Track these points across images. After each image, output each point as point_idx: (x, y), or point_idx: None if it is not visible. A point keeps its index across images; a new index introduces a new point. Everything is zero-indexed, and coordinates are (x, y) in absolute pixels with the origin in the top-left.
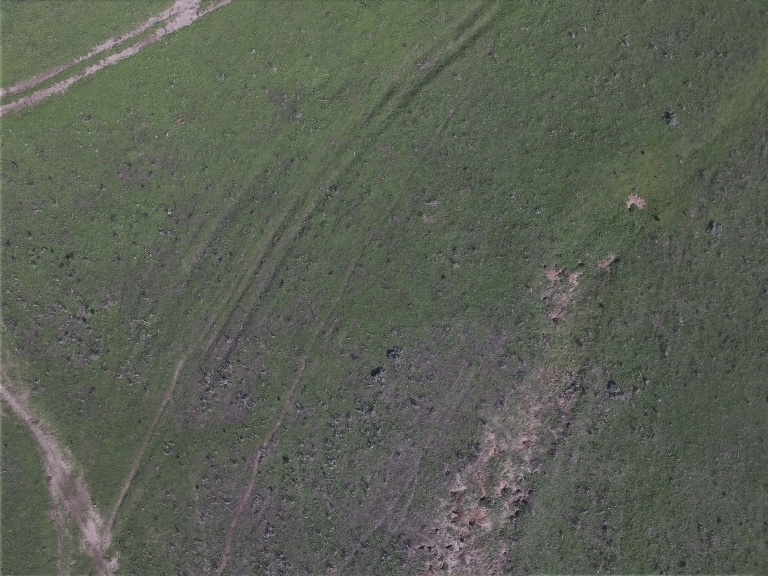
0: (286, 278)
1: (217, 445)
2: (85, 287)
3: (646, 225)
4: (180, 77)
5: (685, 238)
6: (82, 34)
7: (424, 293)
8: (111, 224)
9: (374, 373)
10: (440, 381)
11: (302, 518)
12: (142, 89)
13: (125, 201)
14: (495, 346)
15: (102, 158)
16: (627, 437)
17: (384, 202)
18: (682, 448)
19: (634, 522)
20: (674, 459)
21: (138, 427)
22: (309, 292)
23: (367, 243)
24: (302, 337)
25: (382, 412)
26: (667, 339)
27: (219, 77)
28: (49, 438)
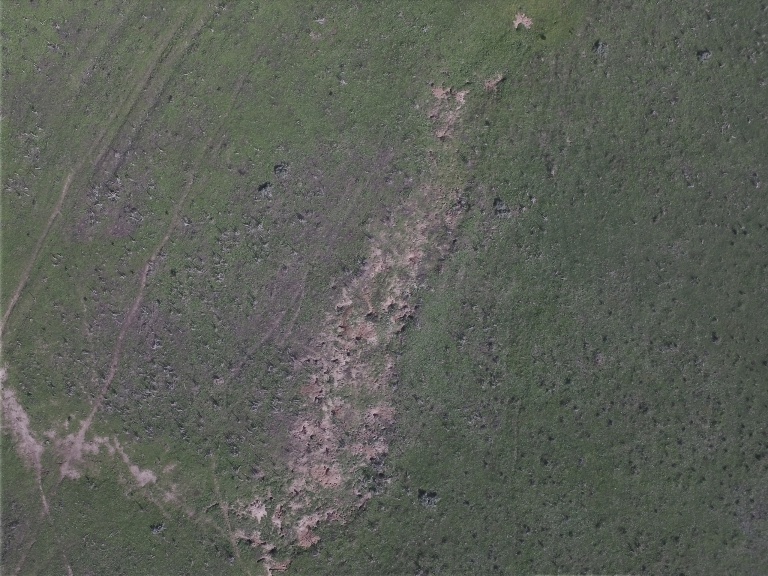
0: (174, 94)
1: (105, 258)
2: None
3: (533, 44)
4: None
5: (571, 57)
6: None
7: (312, 110)
8: None
9: (261, 188)
10: (327, 197)
11: (189, 331)
12: None
13: (14, 16)
14: (382, 163)
15: None
16: (513, 255)
17: (272, 20)
18: (569, 267)
19: (520, 339)
20: (561, 278)
21: (27, 239)
22: (197, 108)
23: (255, 60)
24: (190, 152)
25: (269, 227)
26: (554, 158)
27: None
28: None
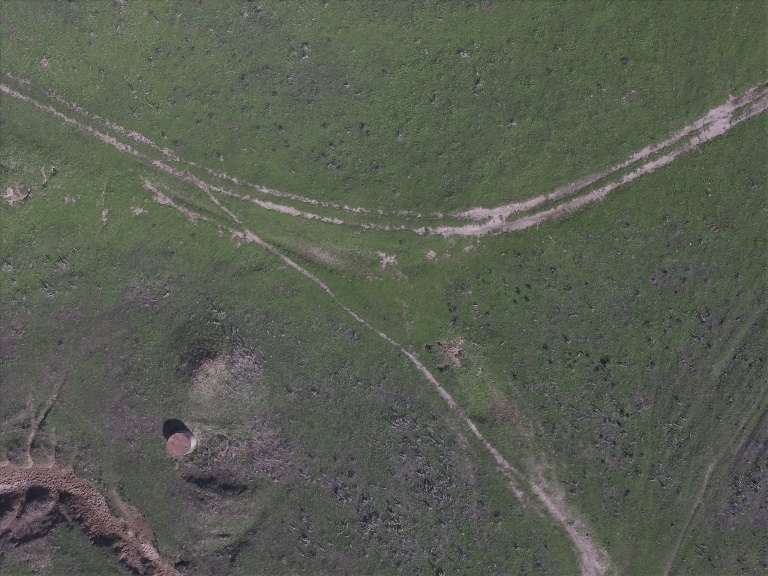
0: None
1: (747, 548)
2: (619, 391)
3: None
4: (714, 185)
5: None
6: (621, 143)
7: None
8: (645, 329)
9: None
10: None
11: None
12: (678, 197)
13: (658, 307)
14: None
15: (638, 265)
16: None
17: None
18: None
19: None
20: None
21: (671, 529)
22: None
23: None
24: None
25: None
26: None
27: (751, 186)
28: (584, 539)
